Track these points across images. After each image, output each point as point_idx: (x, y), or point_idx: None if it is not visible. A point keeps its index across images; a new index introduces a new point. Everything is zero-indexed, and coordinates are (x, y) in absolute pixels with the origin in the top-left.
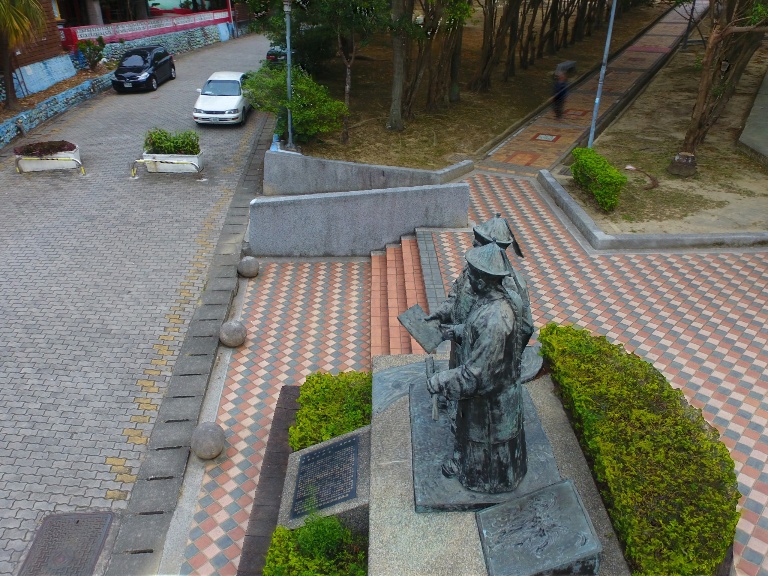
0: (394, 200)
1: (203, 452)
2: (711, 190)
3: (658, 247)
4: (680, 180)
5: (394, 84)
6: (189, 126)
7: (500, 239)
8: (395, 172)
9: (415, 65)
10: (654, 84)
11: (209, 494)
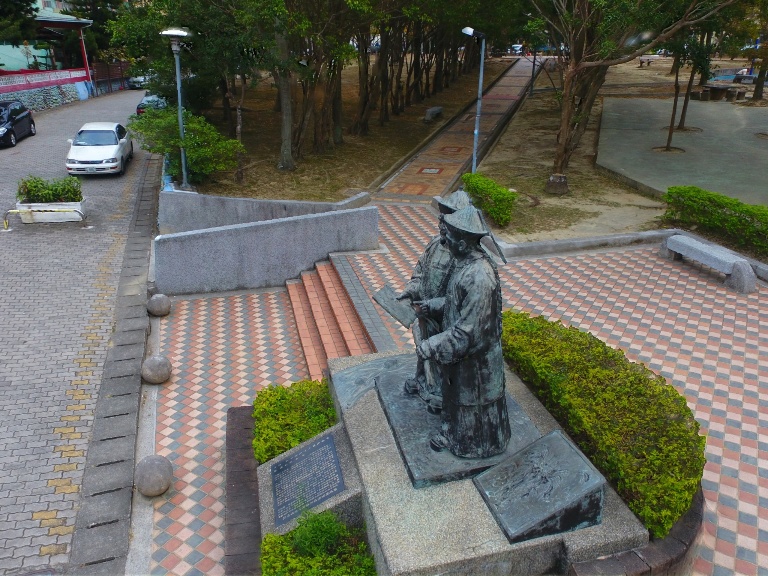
0: (306, 227)
1: (151, 487)
2: (584, 204)
3: (554, 252)
4: (557, 198)
5: (283, 125)
6: (61, 178)
7: None
8: (297, 206)
9: (301, 107)
10: (513, 124)
11: (164, 531)
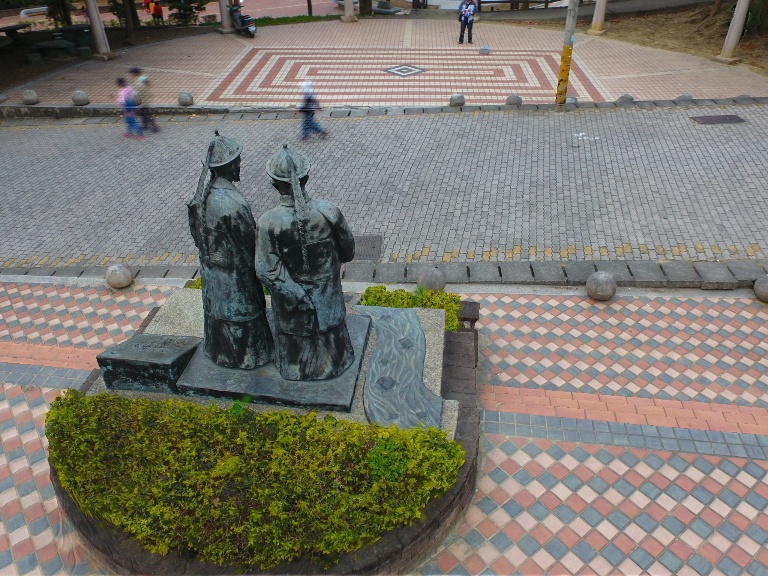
0: None
1: None
2: None
3: None
4: None
5: None
6: None
7: None
8: None
9: None
10: None
11: None
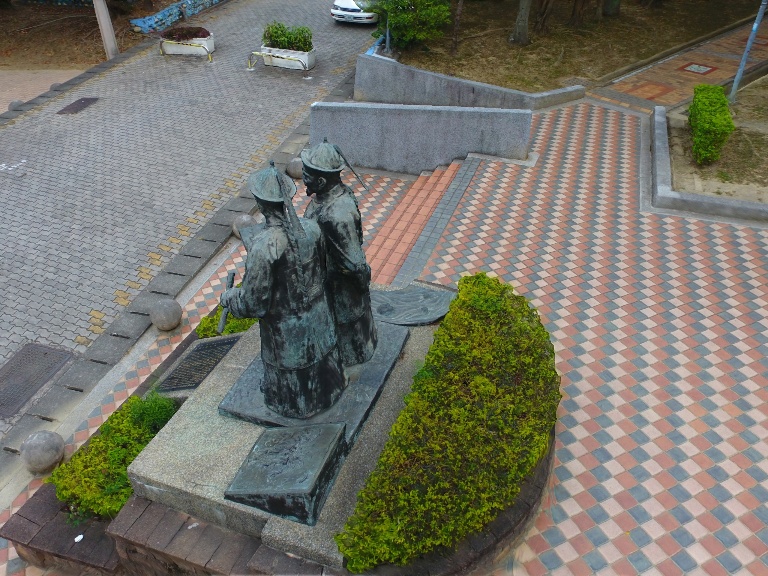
0: (449, 119)
1: (156, 323)
2: None
3: (734, 216)
4: None
5: None
6: (328, 22)
7: (321, 166)
8: (486, 90)
9: None
10: None
11: (148, 359)
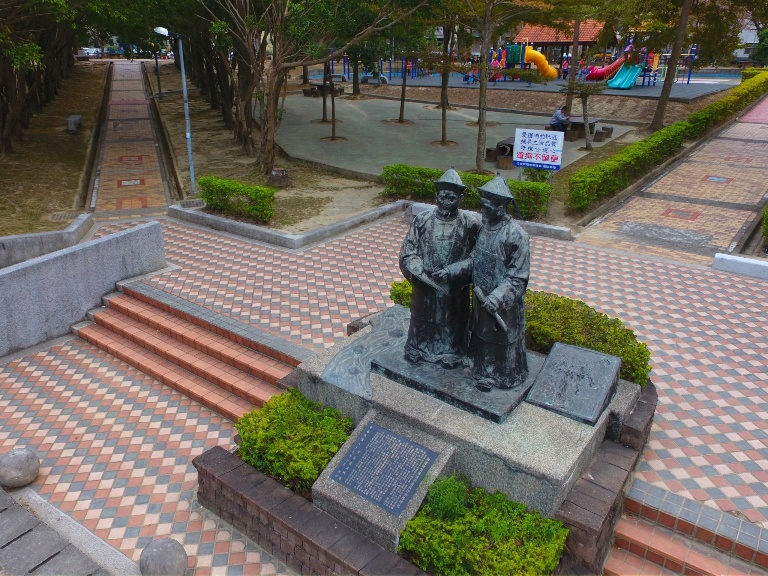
0: (86, 258)
1: (176, 575)
2: (311, 192)
3: (331, 235)
4: (284, 190)
5: None
6: None
7: None
8: (18, 241)
9: None
10: (170, 128)
11: None
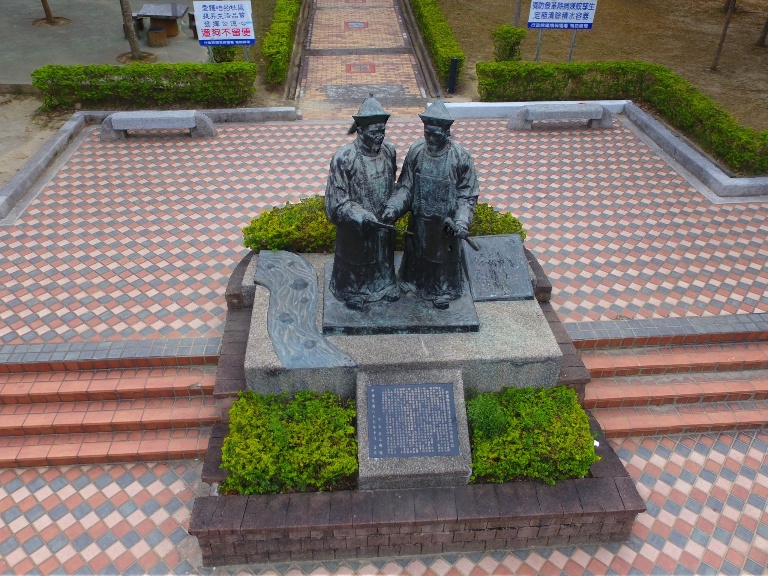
0: None
1: None
2: None
3: (32, 184)
4: None
5: None
6: None
7: None
8: None
9: None
10: None
11: None
